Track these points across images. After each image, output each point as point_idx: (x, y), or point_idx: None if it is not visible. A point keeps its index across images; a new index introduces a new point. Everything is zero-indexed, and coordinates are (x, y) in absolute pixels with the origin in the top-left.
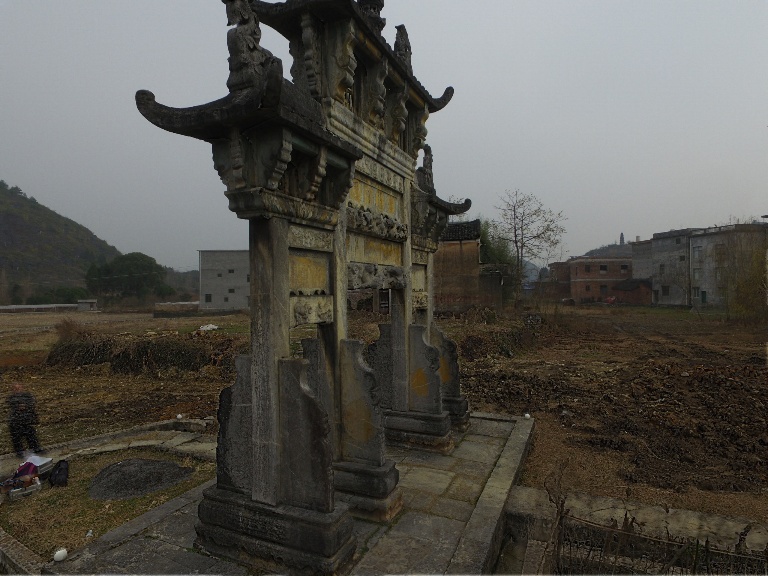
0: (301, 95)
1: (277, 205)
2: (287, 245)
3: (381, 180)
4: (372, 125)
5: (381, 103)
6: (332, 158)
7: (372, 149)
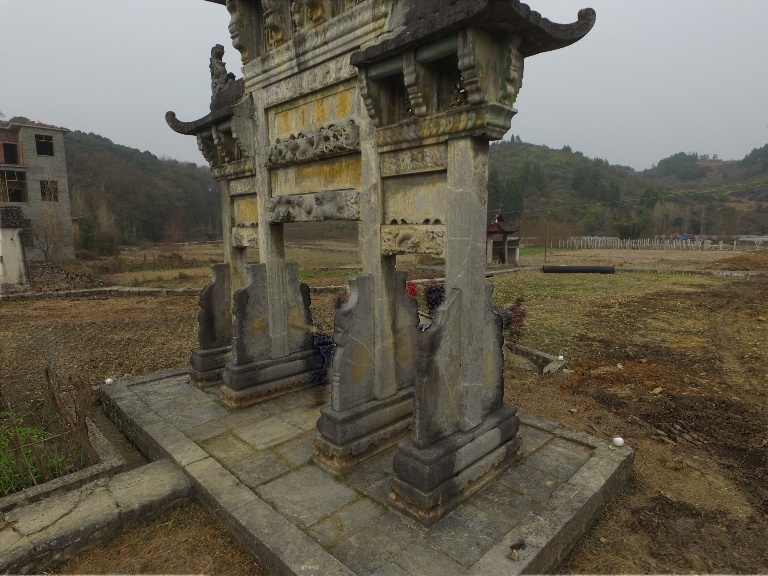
0: (235, 85)
1: (216, 174)
2: (227, 195)
3: (311, 89)
4: (282, 42)
5: (270, 16)
6: (222, 127)
7: (288, 67)
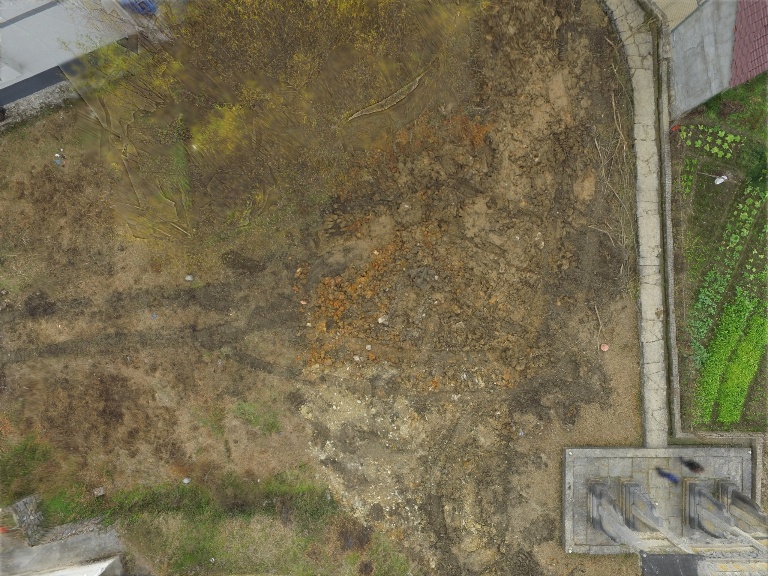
0: None
1: None
2: None
3: None
4: None
5: None
6: None
7: None
